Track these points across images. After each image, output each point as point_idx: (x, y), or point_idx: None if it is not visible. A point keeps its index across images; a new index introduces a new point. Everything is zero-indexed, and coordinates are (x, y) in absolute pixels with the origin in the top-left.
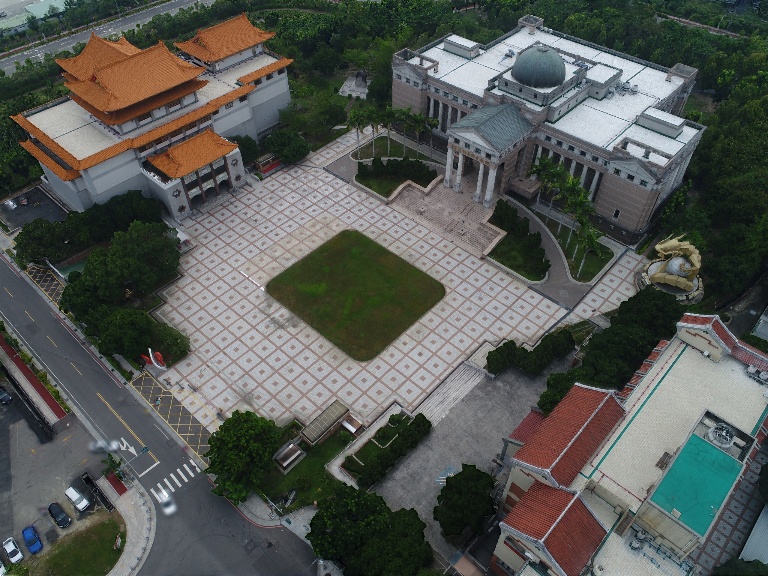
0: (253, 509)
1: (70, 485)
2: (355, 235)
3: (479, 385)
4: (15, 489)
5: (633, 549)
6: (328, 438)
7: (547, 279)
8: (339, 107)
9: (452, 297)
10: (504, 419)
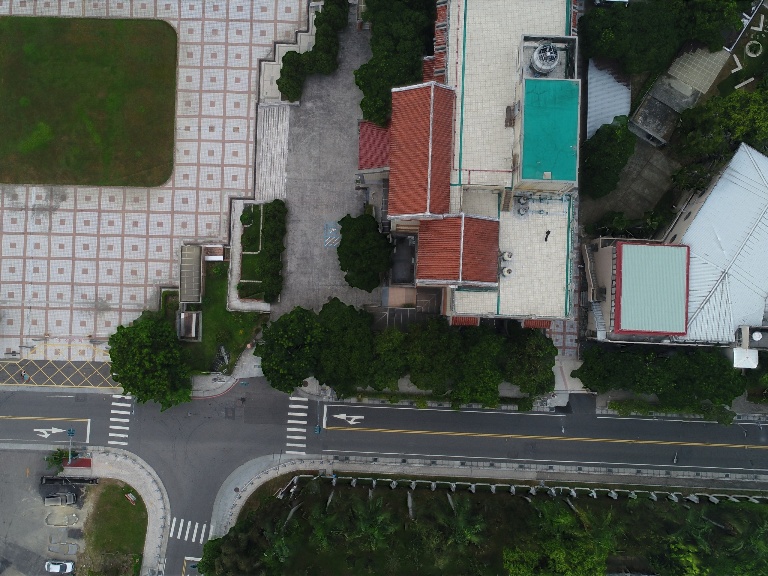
0: (204, 388)
1: (41, 495)
2: (7, 25)
3: (292, 122)
4: (1, 535)
5: (522, 215)
6: (206, 282)
7: None
8: None
9: (186, 30)
10: (338, 140)
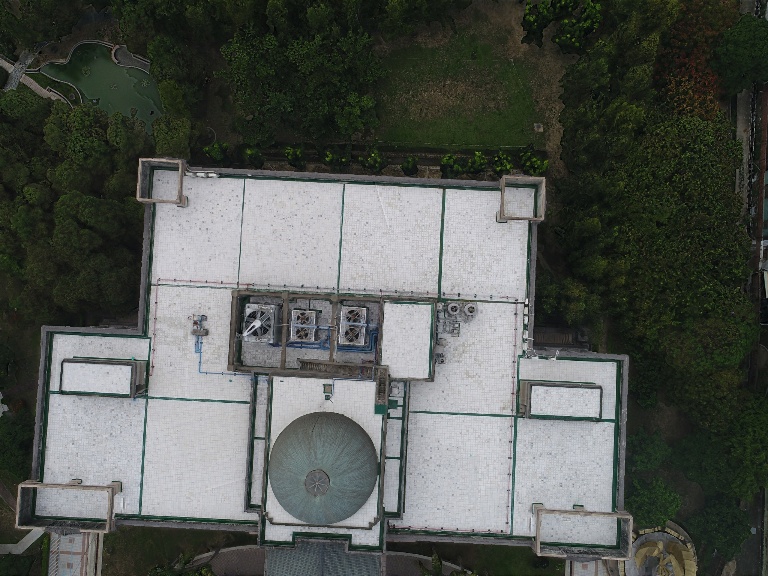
0: None
1: None
2: None
3: None
4: None
5: None
6: None
7: None
8: (6, 573)
9: None
10: None
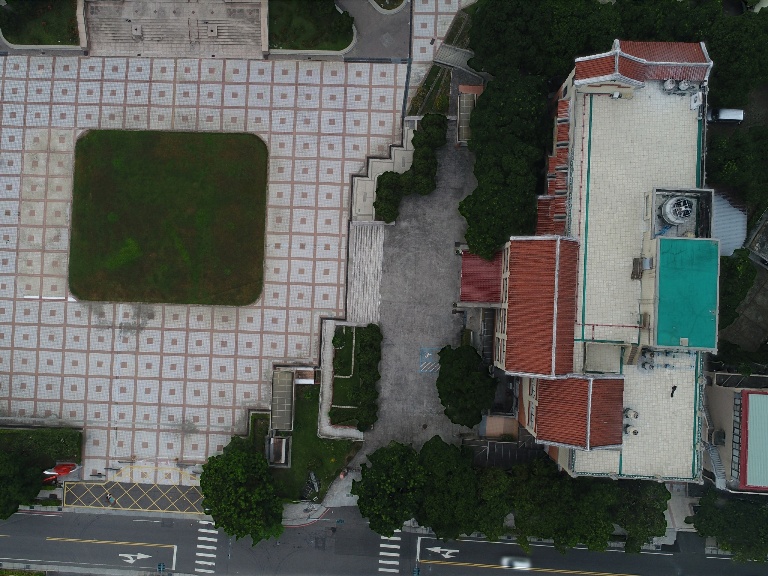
0: (293, 516)
1: None
2: (96, 139)
3: (386, 242)
4: None
5: (647, 369)
6: (296, 406)
7: (357, 32)
8: None
9: (276, 144)
10: (434, 261)
